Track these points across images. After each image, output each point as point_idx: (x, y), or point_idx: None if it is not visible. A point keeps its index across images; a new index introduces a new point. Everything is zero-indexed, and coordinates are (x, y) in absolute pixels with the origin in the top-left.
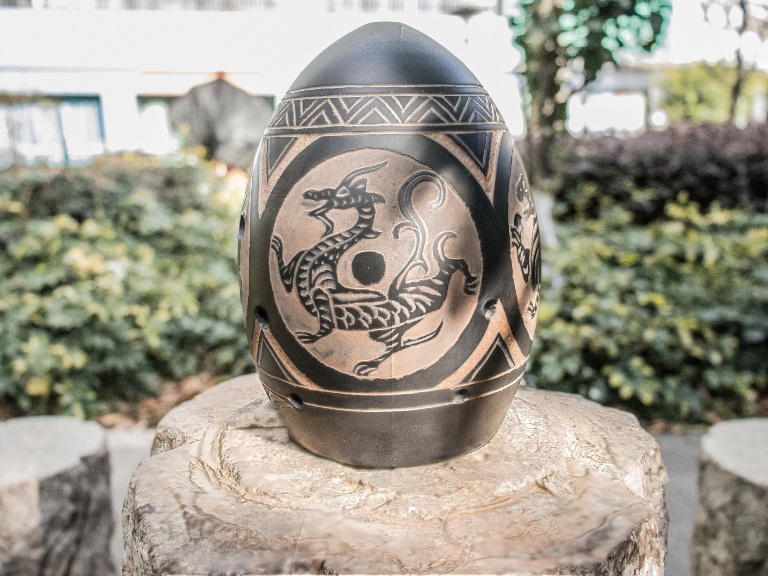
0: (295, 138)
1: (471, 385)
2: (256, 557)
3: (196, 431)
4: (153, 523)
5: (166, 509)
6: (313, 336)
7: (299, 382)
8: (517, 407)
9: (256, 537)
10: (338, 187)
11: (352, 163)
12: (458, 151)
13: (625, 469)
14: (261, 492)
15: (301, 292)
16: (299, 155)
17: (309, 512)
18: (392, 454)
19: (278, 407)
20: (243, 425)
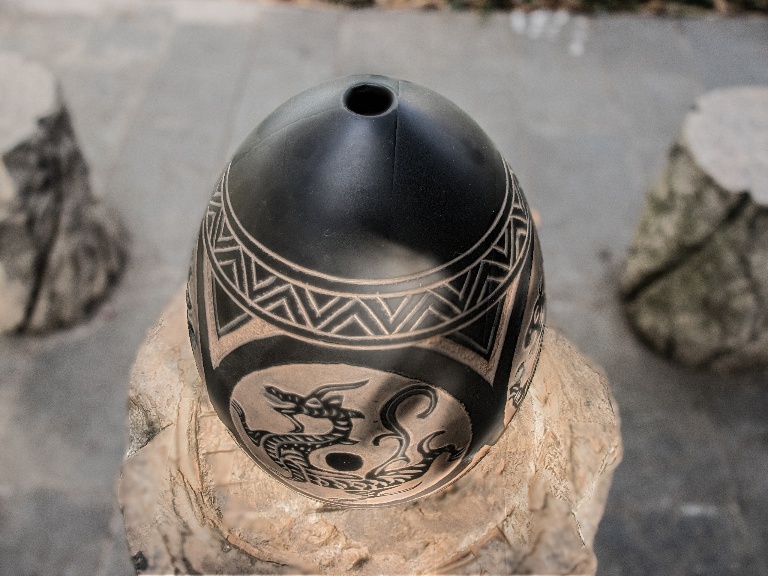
0: (249, 316)
1: None
2: None
3: (169, 404)
4: None
5: (158, 563)
6: None
7: None
8: None
9: None
10: (308, 397)
11: (324, 377)
12: (458, 348)
13: (581, 493)
14: (243, 540)
15: (270, 454)
16: (256, 343)
17: (289, 571)
18: None
19: None
20: None
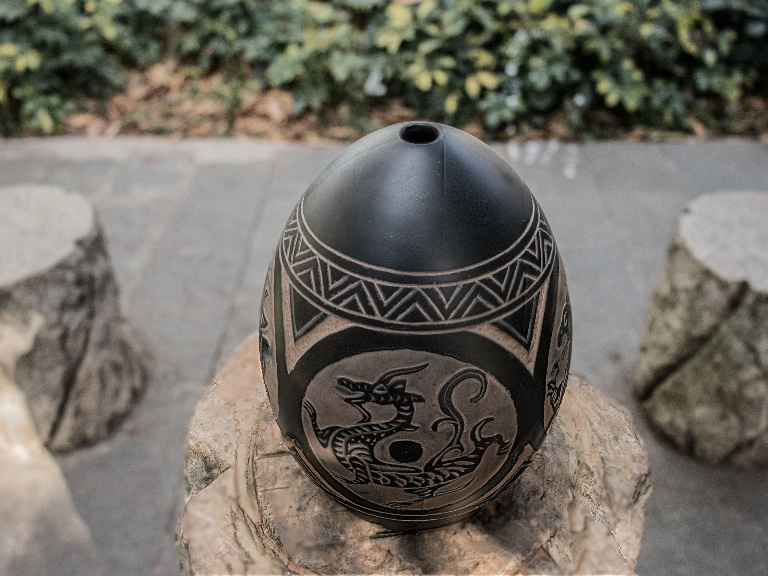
0: (325, 314)
1: (493, 496)
2: None
3: (227, 450)
4: None
5: None
6: (349, 481)
7: None
8: None
9: None
10: (375, 384)
11: (390, 362)
12: (503, 336)
13: (618, 516)
14: (303, 565)
15: (337, 453)
16: (331, 337)
17: None
18: None
19: None
20: (271, 449)
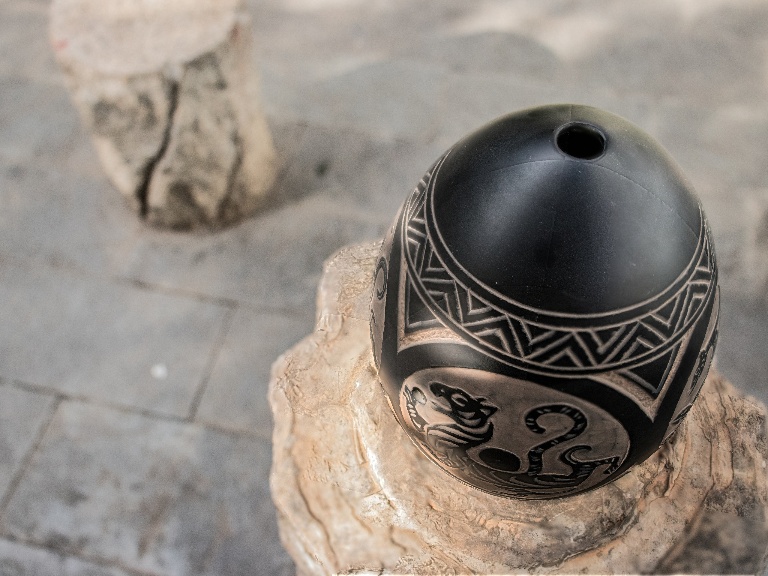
0: None
1: None
2: (333, 294)
3: None
4: None
5: None
6: None
7: None
8: (547, 531)
9: (353, 293)
10: None
11: None
12: None
13: None
14: None
15: None
16: None
17: None
18: None
19: None
20: None
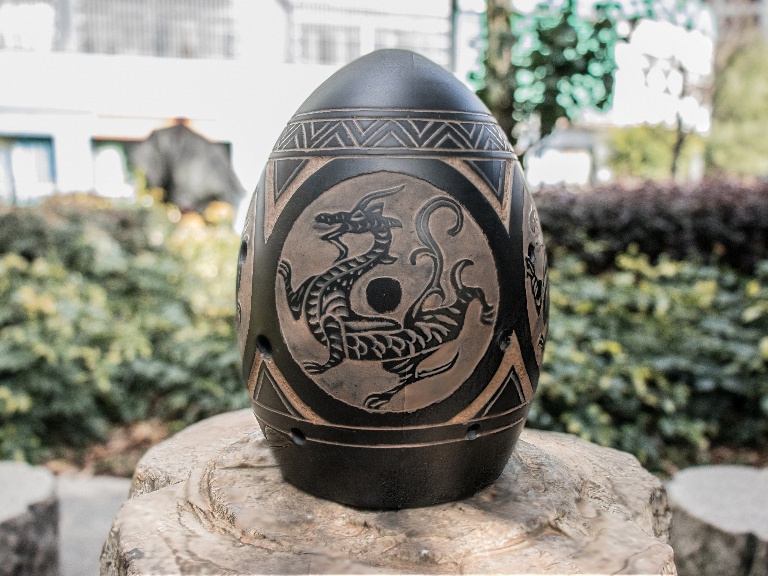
0: (306, 160)
1: (484, 420)
2: None
3: (180, 471)
4: (143, 570)
5: (156, 554)
6: (321, 366)
7: (303, 416)
8: (516, 447)
9: None
10: (353, 210)
11: (368, 186)
12: (475, 178)
13: (636, 510)
14: (259, 535)
15: (310, 320)
16: (311, 177)
17: (314, 556)
18: (398, 494)
19: (267, 446)
20: (232, 464)
